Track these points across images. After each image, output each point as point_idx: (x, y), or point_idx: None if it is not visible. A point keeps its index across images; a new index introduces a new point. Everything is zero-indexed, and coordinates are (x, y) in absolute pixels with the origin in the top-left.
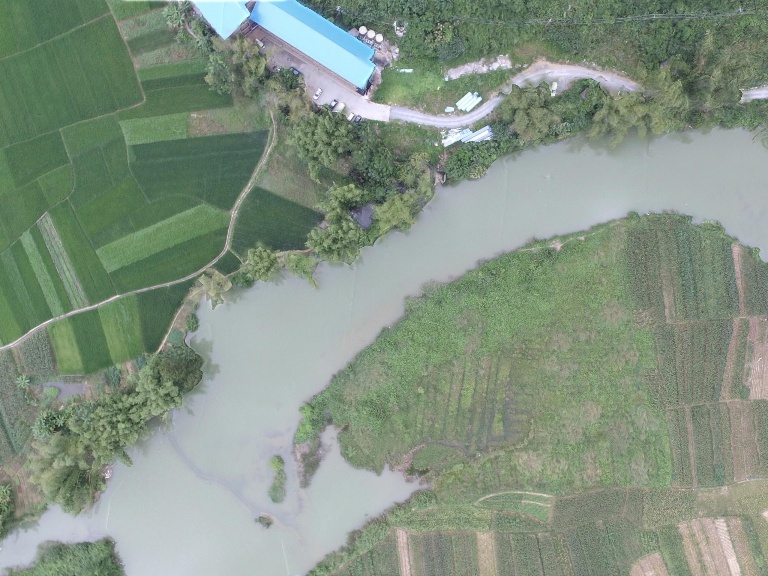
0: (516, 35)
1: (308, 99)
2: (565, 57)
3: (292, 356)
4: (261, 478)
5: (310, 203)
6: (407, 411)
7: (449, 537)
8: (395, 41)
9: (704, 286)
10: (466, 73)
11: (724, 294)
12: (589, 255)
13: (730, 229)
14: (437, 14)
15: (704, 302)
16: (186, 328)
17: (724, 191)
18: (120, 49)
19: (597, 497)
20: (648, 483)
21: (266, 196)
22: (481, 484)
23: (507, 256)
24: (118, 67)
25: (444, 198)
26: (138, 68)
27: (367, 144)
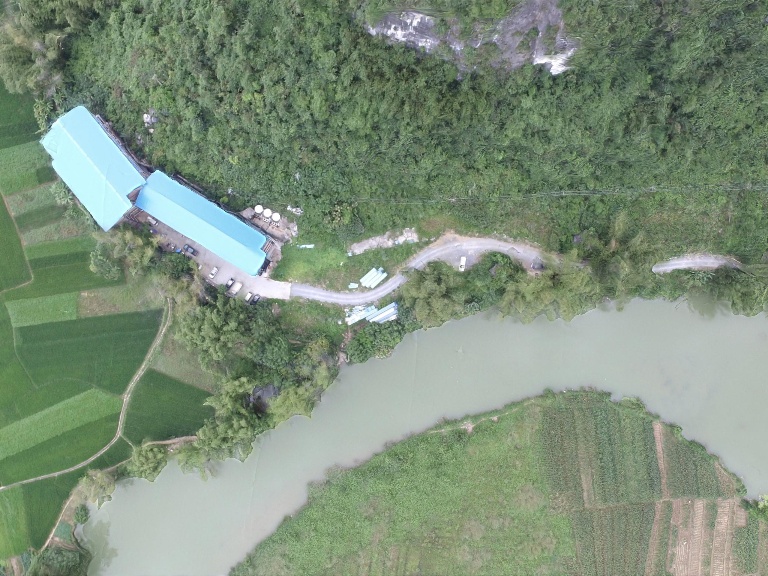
0: (421, 210)
1: (195, 292)
2: (474, 230)
3: (191, 542)
4: None
5: (207, 385)
6: None
7: None
8: (293, 218)
9: (624, 467)
10: (370, 248)
11: (645, 477)
12: (502, 437)
13: (651, 405)
14: (334, 196)
15: (624, 485)
16: (74, 521)
17: (645, 365)
18: (7, 226)
19: None
20: None
21: (160, 379)
22: None
23: (415, 439)
24: (4, 245)
25: (352, 371)
26: (26, 245)
27: (258, 337)
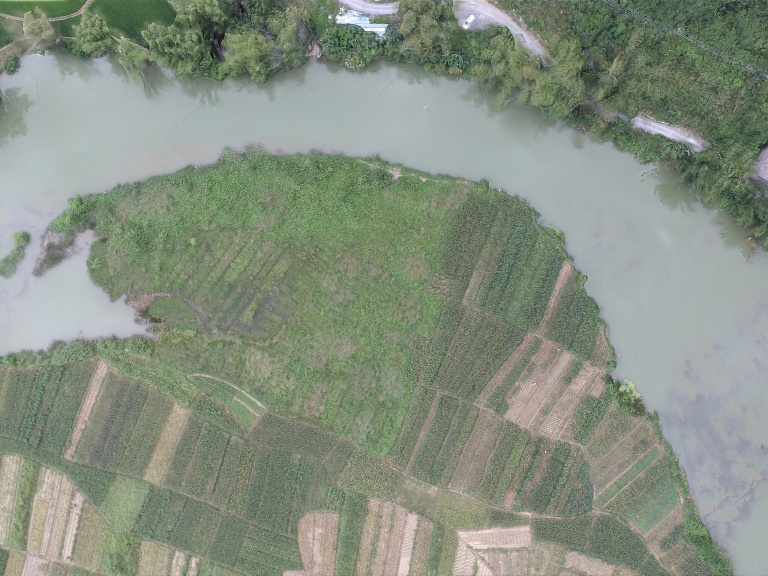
0: None
1: None
2: None
3: (96, 151)
4: (0, 245)
5: None
6: (170, 254)
7: (146, 393)
8: None
9: (516, 286)
10: None
11: (531, 303)
12: (421, 198)
13: (571, 246)
14: None
15: (508, 301)
16: (2, 66)
17: (585, 207)
18: None
19: (306, 430)
20: (363, 444)
21: None
22: (203, 360)
23: (342, 158)
24: None
25: (319, 79)
26: None
27: None
